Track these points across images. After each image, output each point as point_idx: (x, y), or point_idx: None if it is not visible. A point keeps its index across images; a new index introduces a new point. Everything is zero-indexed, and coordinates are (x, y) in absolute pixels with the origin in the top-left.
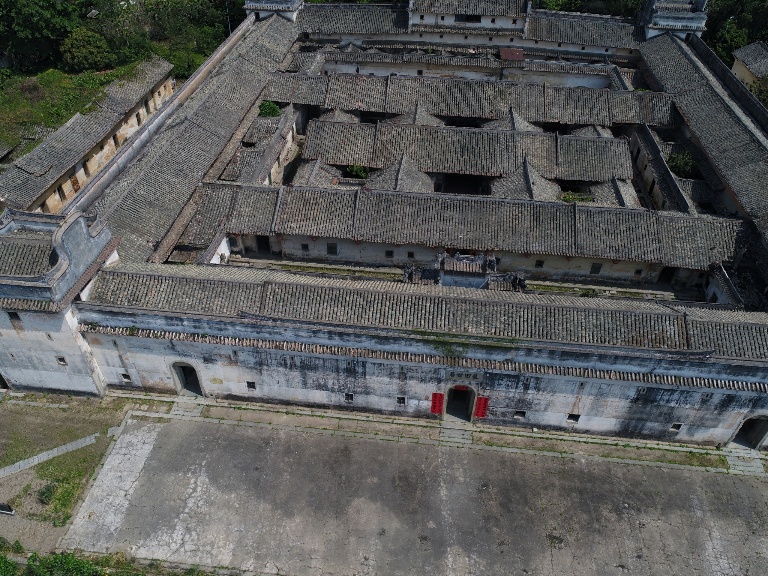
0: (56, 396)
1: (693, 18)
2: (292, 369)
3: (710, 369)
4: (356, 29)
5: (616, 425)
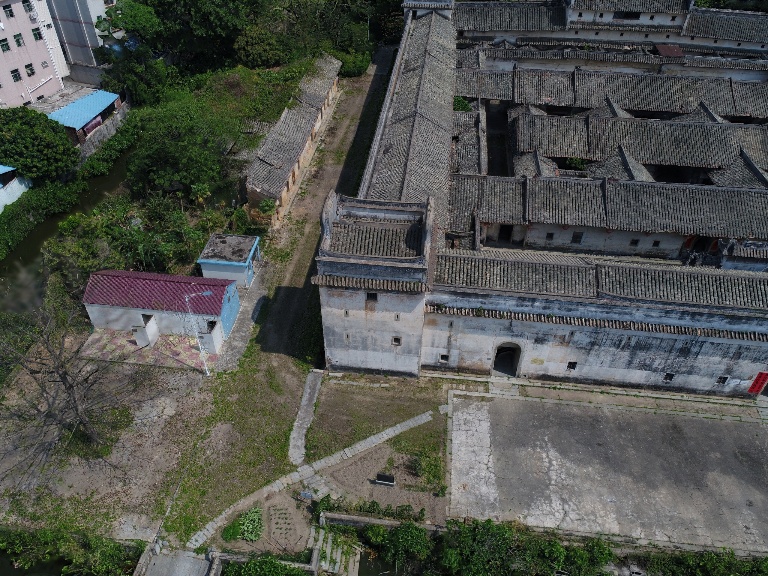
0: (373, 376)
1: None
2: (623, 349)
3: None
4: (513, 26)
5: None
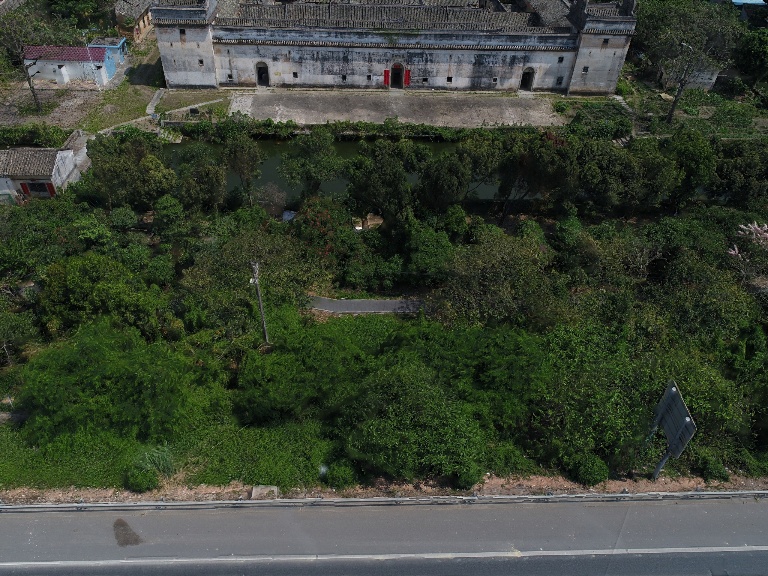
0: (193, 90)
1: None
2: (317, 61)
3: (502, 39)
4: None
5: (469, 82)
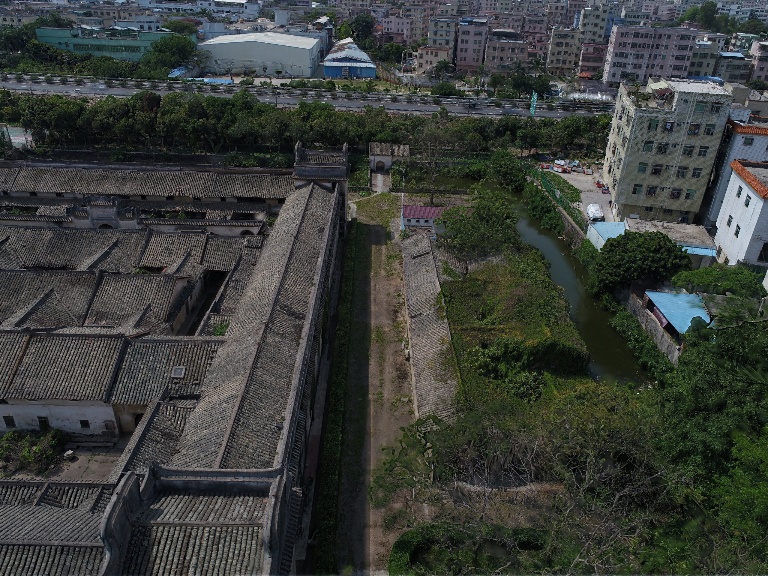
0: None
1: None
2: None
3: None
4: None
5: None
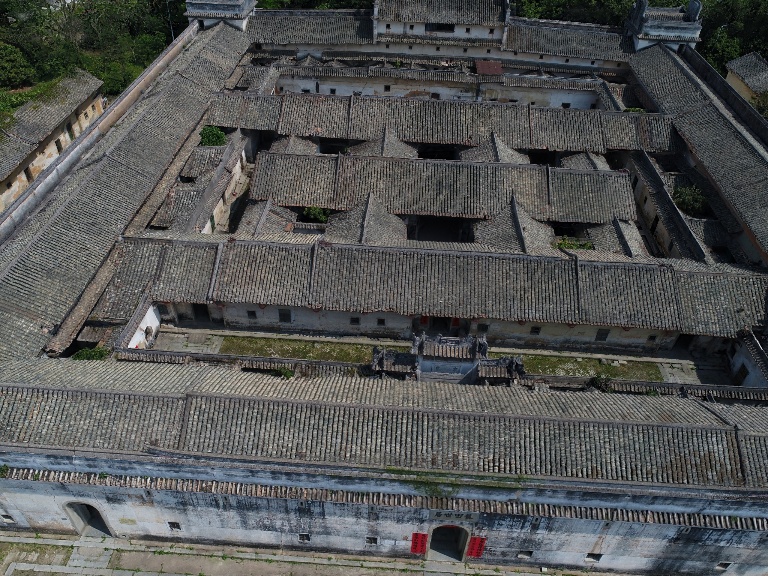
0: None
1: (687, 28)
2: (226, 509)
3: None
4: (314, 39)
5: (647, 564)
